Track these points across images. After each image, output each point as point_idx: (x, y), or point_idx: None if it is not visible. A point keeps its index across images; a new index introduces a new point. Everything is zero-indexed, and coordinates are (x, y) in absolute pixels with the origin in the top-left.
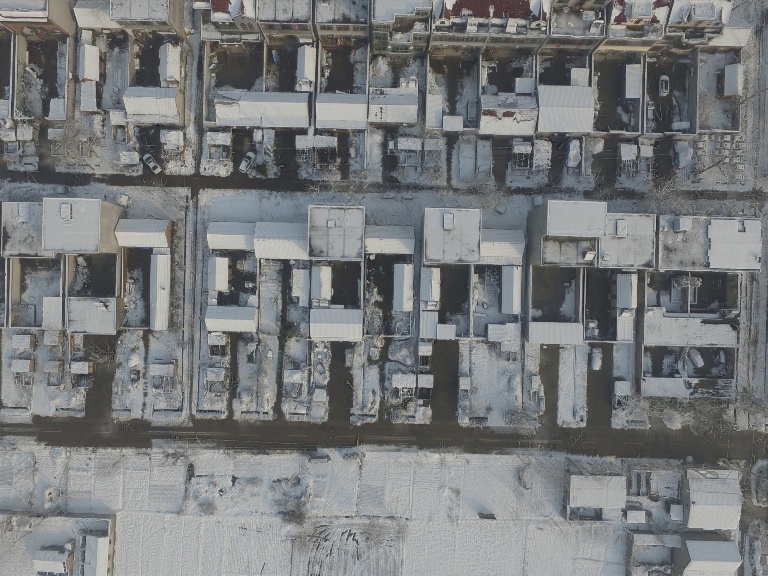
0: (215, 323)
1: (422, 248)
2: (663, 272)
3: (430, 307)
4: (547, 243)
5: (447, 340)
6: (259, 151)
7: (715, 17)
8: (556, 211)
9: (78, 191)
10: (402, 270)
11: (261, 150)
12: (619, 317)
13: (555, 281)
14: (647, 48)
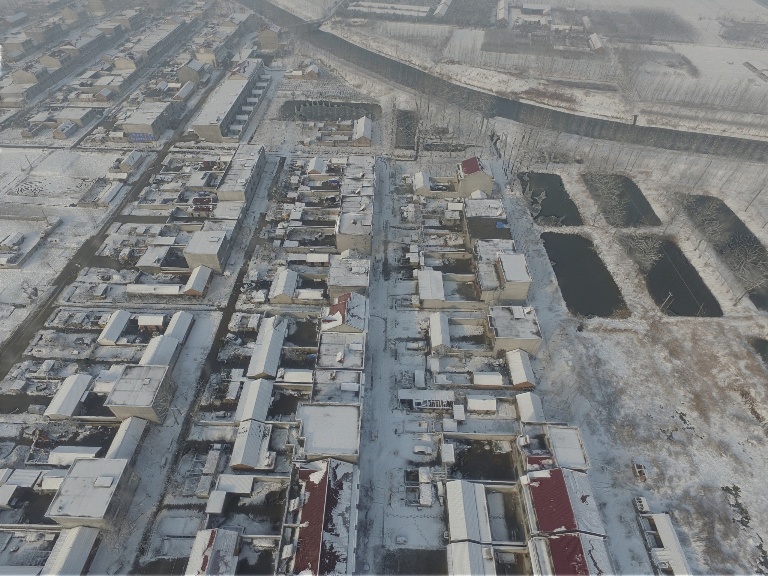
0: None
1: None
2: None
3: None
4: None
5: None
6: None
7: None
8: None
9: (241, 254)
10: (91, 452)
11: None
12: None
13: None
14: None
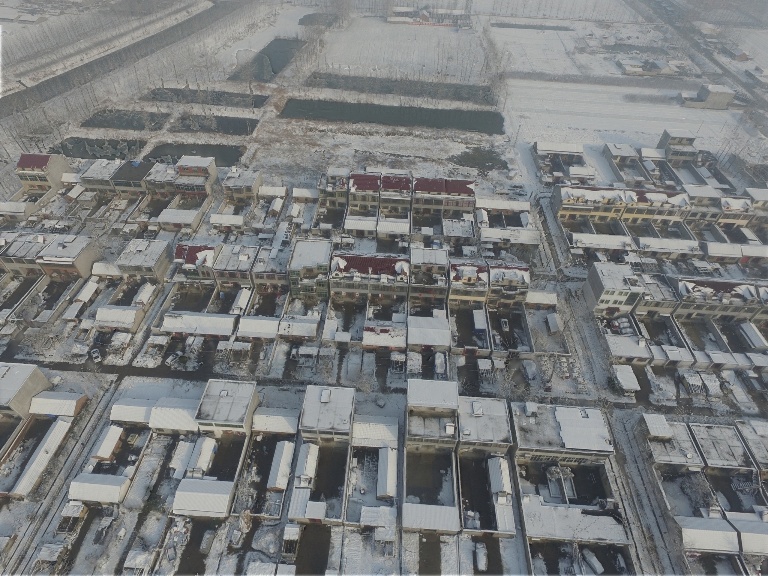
0: (80, 488)
1: None
2: (536, 465)
3: (303, 483)
4: (412, 418)
5: (319, 527)
6: (187, 352)
7: (519, 279)
8: (415, 387)
9: None
10: (282, 446)
11: None
12: (496, 504)
13: (432, 468)
14: (483, 298)
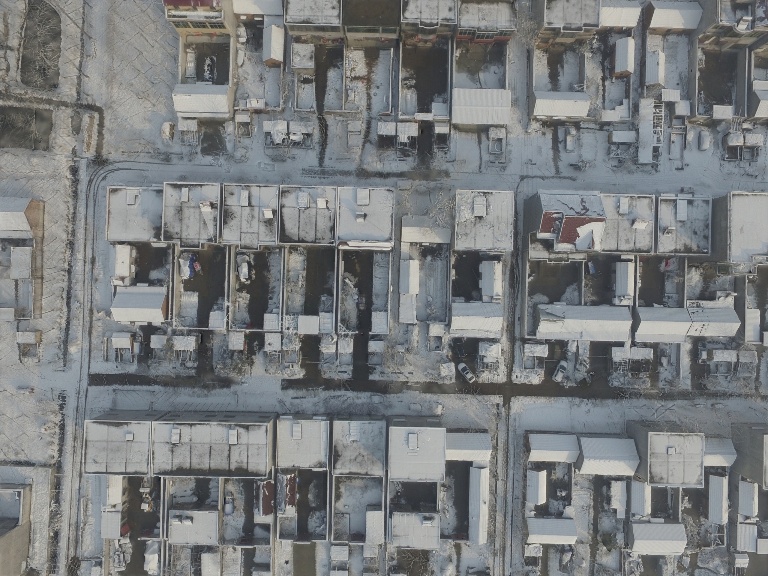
0: (537, 538)
1: (744, 463)
2: None
3: (749, 521)
4: None
5: None
6: (570, 358)
7: None
8: None
9: (392, 399)
10: (720, 483)
11: (572, 358)
12: None
13: None
14: None
